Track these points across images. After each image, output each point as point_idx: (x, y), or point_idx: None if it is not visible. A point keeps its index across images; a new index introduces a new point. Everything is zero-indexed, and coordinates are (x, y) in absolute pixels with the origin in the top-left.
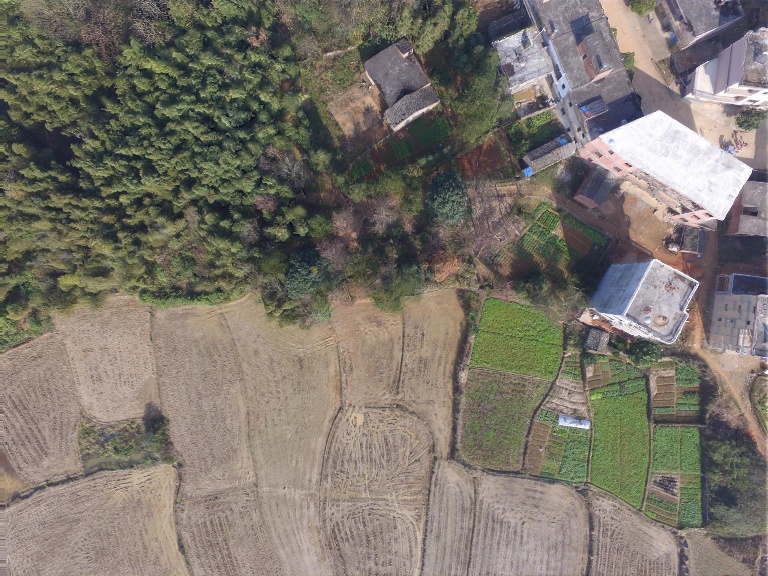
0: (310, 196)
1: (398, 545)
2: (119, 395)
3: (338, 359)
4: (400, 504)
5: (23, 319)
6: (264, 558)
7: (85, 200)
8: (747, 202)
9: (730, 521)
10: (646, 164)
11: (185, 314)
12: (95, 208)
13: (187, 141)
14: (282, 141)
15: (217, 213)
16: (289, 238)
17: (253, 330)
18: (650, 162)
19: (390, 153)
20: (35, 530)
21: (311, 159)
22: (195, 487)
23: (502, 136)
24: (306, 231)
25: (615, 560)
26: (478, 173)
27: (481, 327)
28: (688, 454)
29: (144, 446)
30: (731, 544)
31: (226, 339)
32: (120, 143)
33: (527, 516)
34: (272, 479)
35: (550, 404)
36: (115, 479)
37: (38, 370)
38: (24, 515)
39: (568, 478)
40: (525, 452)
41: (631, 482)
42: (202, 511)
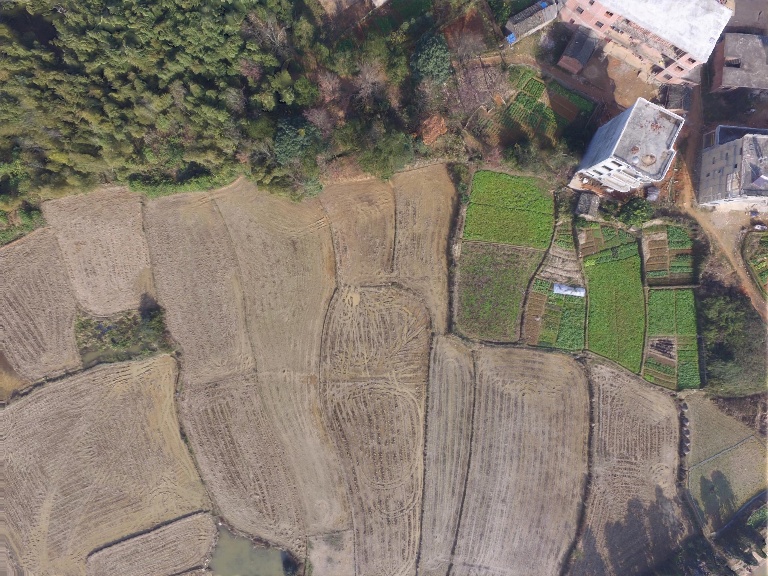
0: (296, 77)
1: (400, 423)
2: (114, 287)
3: (331, 240)
4: (400, 382)
5: (14, 211)
6: (267, 443)
7: (69, 75)
8: (729, 54)
9: (728, 377)
10: (627, 10)
11: (176, 202)
12: (80, 83)
13: (169, 10)
14: (264, 11)
15: (203, 85)
16: (276, 107)
17: (245, 215)
18: (631, 8)
19: (373, 29)
20: (36, 427)
21: (294, 32)
22: (194, 375)
23: (484, 6)
24: (292, 99)
25: (616, 427)
26: (462, 45)
27: (472, 200)
28: (683, 316)
29: (141, 337)
30: (730, 403)
31: (218, 225)
32: (102, 14)
33: (527, 387)
34: (271, 363)
35: (544, 273)
36: (114, 372)
37: (31, 266)
38: (24, 412)
39: (566, 346)
40: (522, 322)
41: (628, 347)
42: (203, 399)
